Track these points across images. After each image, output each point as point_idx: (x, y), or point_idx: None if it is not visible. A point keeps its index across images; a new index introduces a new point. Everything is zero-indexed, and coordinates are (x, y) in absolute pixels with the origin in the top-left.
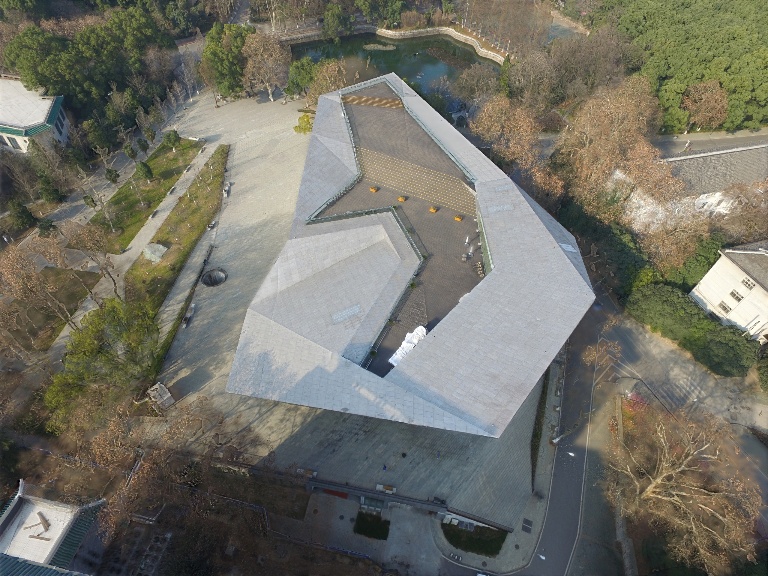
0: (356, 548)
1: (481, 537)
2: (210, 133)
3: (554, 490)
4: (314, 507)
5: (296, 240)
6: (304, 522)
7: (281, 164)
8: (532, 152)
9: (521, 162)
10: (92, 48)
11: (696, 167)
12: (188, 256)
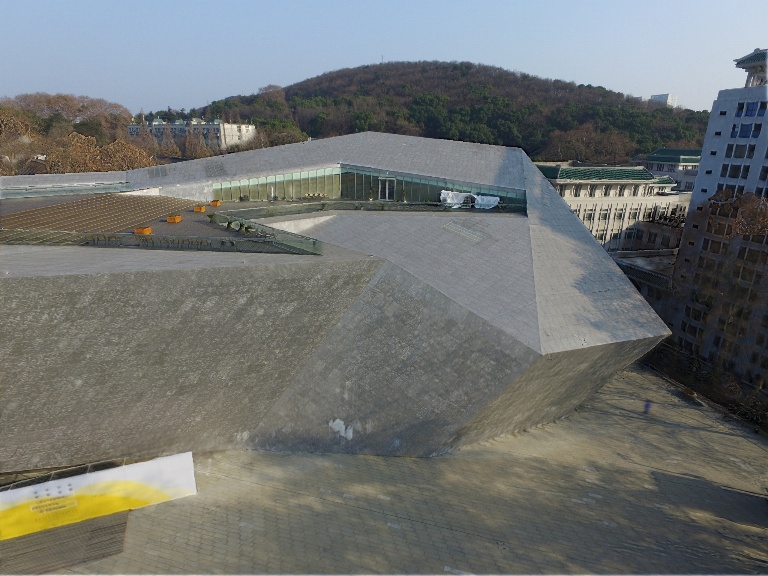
0: None
1: None
2: None
3: None
4: None
5: None
6: None
7: None
8: None
9: None
10: None
11: None
12: None
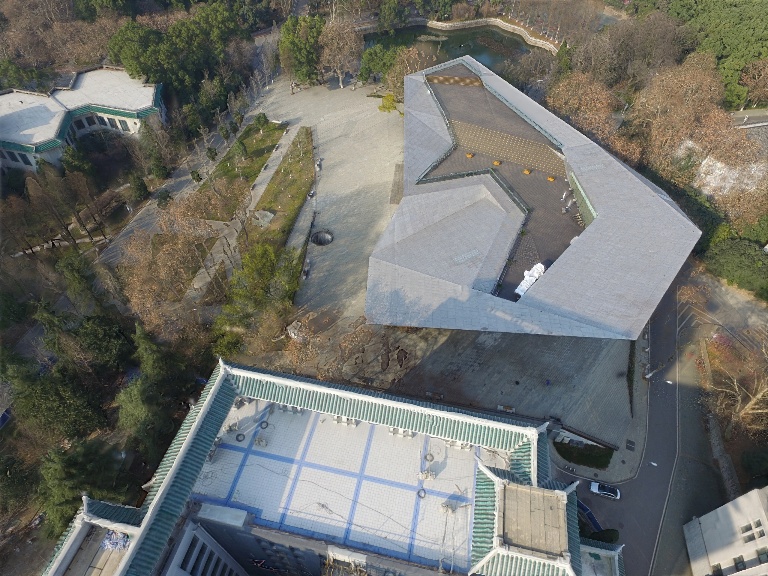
0: None
1: (591, 453)
2: (291, 117)
3: (651, 417)
4: None
5: (410, 197)
6: None
7: (363, 142)
8: (608, 122)
9: (597, 132)
10: (184, 40)
11: (764, 134)
12: (294, 221)
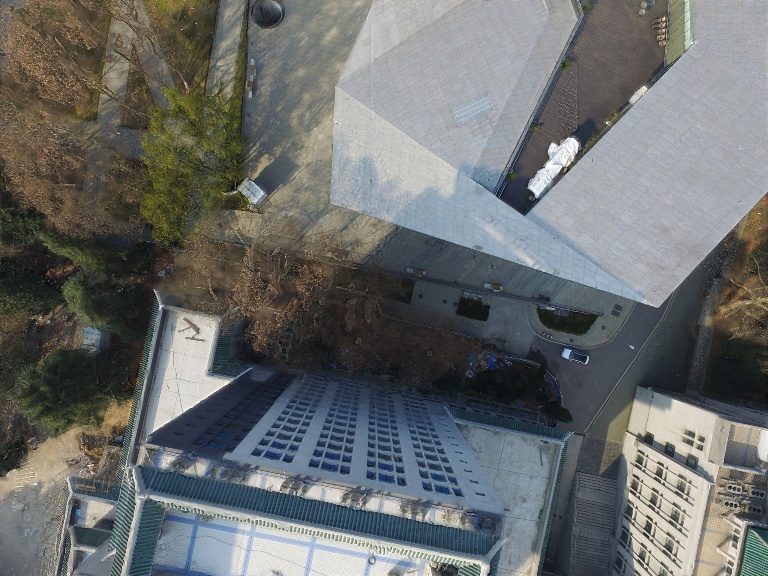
0: (459, 327)
1: (573, 321)
2: None
3: None
4: (419, 293)
5: None
6: (411, 305)
7: None
8: None
9: None
10: None
11: None
12: None
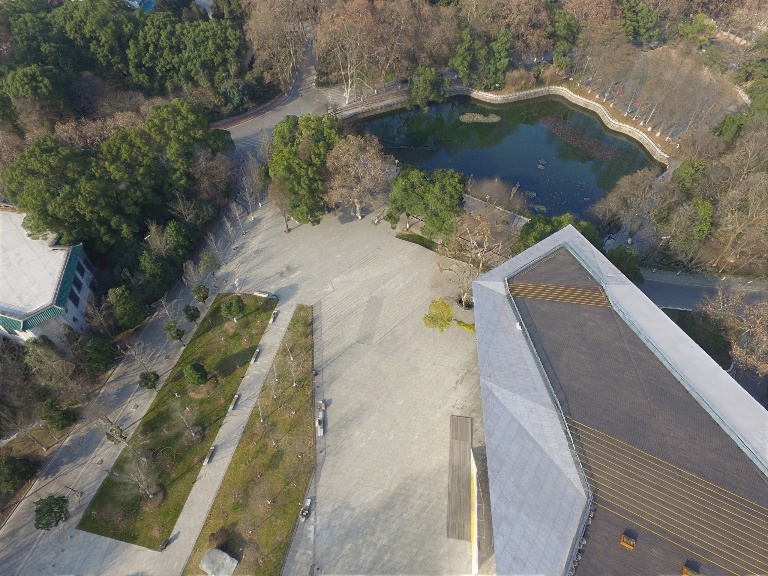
0: None
1: None
2: (282, 282)
3: None
4: None
5: None
6: None
7: (394, 356)
8: None
9: None
10: (123, 167)
11: None
12: None
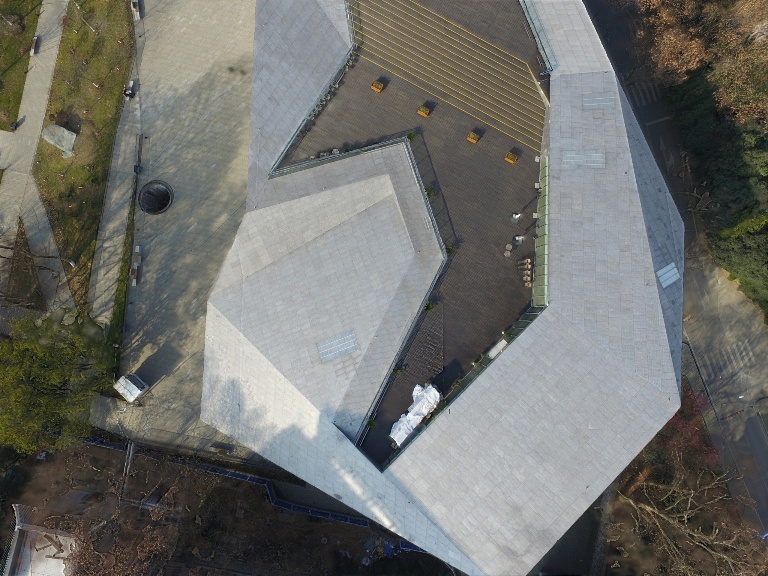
0: None
1: None
2: None
3: None
4: None
5: (257, 212)
6: (306, 488)
7: None
8: None
9: None
10: None
11: None
12: (109, 153)
